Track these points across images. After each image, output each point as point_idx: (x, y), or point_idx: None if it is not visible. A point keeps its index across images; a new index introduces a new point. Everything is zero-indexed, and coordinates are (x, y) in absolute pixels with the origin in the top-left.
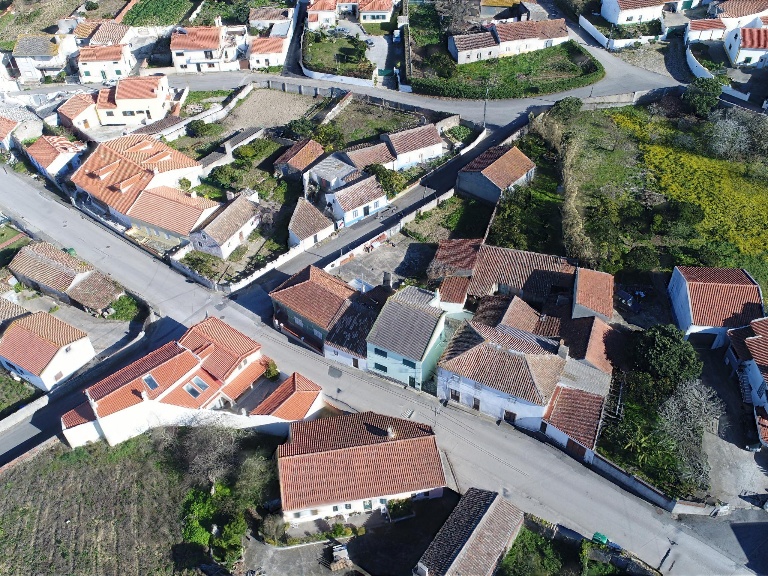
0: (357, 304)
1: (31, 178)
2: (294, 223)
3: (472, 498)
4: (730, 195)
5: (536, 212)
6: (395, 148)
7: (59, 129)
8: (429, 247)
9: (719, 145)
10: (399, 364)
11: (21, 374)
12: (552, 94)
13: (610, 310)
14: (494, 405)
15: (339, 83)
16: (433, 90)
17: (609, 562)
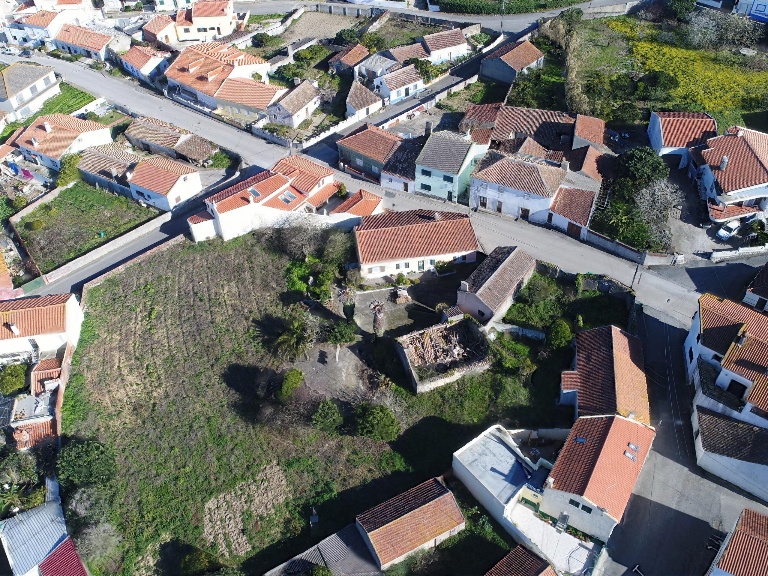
0: (406, 143)
1: (126, 79)
2: (351, 98)
3: (498, 251)
4: (701, 72)
5: (545, 89)
6: (429, 46)
7: (145, 43)
8: (459, 115)
9: (693, 36)
10: (440, 181)
11: (148, 200)
12: (558, 9)
13: (601, 141)
14: (513, 205)
15: (377, 6)
16: (458, 8)
17: (597, 289)
